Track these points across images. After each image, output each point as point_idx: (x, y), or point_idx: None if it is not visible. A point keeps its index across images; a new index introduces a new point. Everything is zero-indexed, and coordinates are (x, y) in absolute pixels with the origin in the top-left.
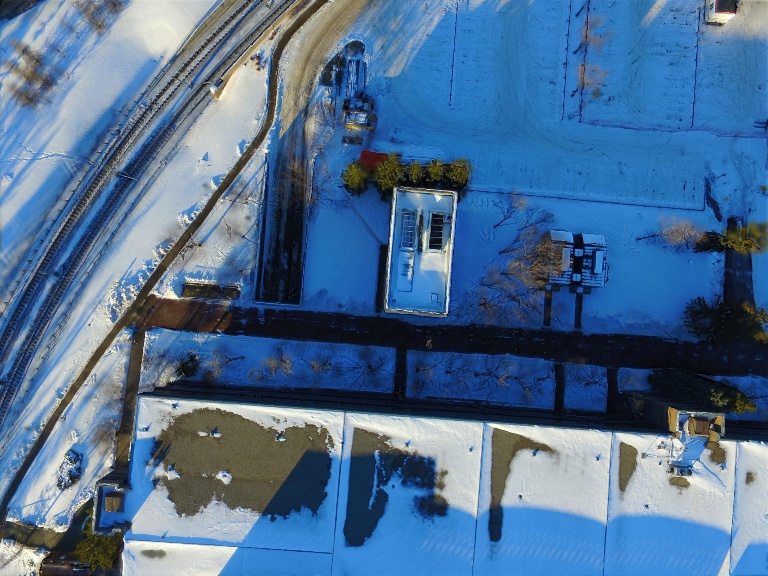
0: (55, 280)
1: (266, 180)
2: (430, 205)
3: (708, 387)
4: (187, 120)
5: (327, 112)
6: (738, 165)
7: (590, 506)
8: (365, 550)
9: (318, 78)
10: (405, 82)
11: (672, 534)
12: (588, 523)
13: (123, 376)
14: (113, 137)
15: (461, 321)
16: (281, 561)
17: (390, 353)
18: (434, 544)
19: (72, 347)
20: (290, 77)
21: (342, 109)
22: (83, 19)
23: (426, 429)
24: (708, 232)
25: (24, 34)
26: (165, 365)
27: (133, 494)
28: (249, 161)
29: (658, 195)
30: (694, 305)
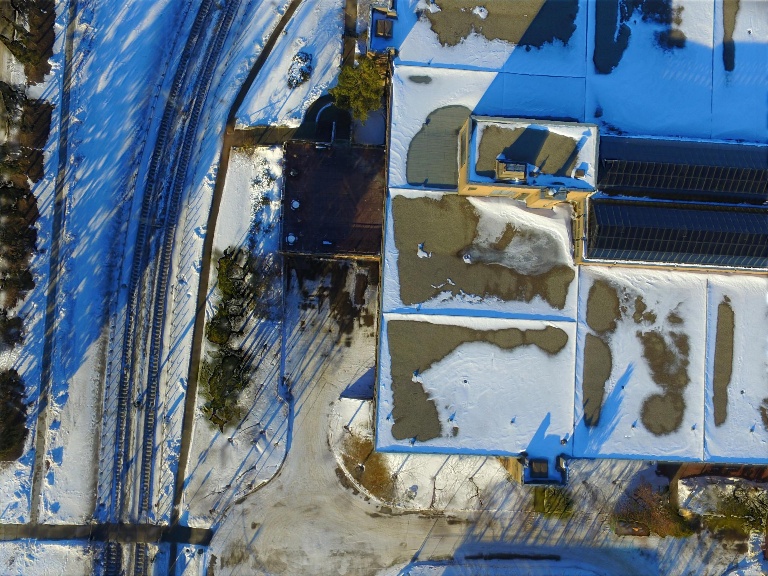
0: None
1: None
2: None
3: None
4: None
5: None
6: None
7: None
8: (613, 77)
9: None
10: None
11: None
12: None
13: None
14: None
15: None
16: (538, 86)
17: None
18: (675, 73)
19: None
20: None
21: None
22: None
23: None
24: None
25: None
26: None
27: (399, 23)
28: None
29: None
30: None
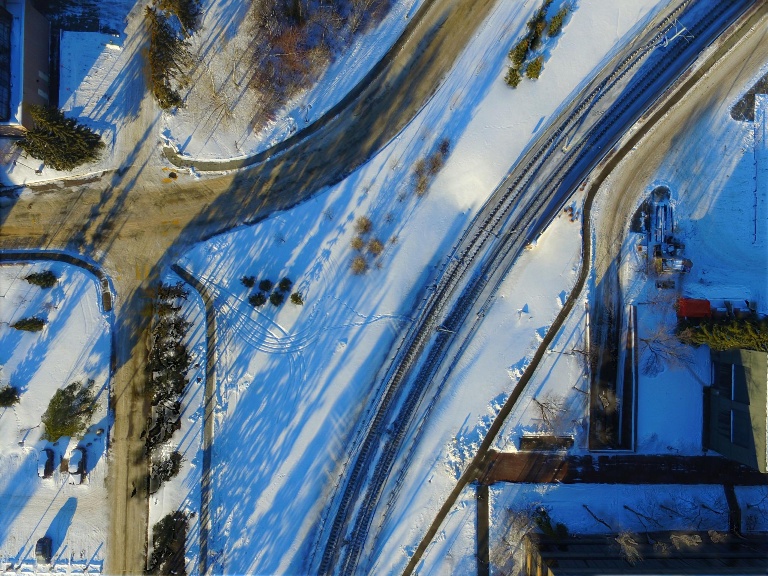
0: (388, 438)
1: (590, 330)
2: None
3: None
4: (497, 270)
5: (640, 258)
6: None
7: None
8: None
9: (629, 225)
10: (710, 224)
11: None
12: None
13: (474, 532)
14: (431, 293)
15: None
16: None
17: (720, 490)
18: None
19: (414, 504)
20: (601, 225)
21: (653, 254)
22: (403, 182)
23: None
24: None
25: (348, 201)
26: (513, 519)
27: None
28: (570, 312)
29: None
30: None
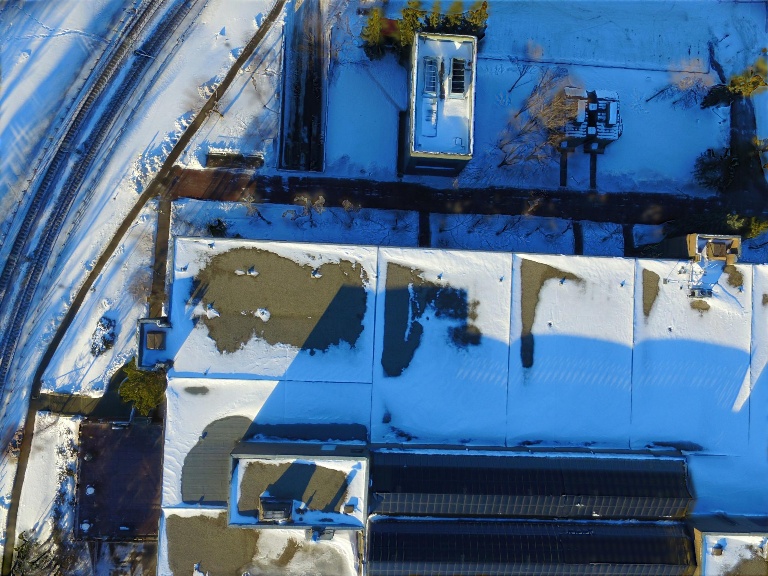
0: (77, 158)
1: (284, 51)
2: (451, 52)
3: (724, 214)
4: None
5: None
6: (739, 29)
7: (616, 330)
8: (403, 380)
9: None
10: None
11: (695, 355)
12: (615, 347)
13: (151, 245)
14: (129, 16)
15: (481, 183)
16: (322, 393)
17: (413, 216)
18: (469, 372)
19: (98, 221)
20: None
21: None
22: None
23: (457, 261)
24: (715, 85)
25: None
26: (193, 233)
27: (174, 333)
28: (266, 33)
29: (665, 60)
30: (704, 157)
